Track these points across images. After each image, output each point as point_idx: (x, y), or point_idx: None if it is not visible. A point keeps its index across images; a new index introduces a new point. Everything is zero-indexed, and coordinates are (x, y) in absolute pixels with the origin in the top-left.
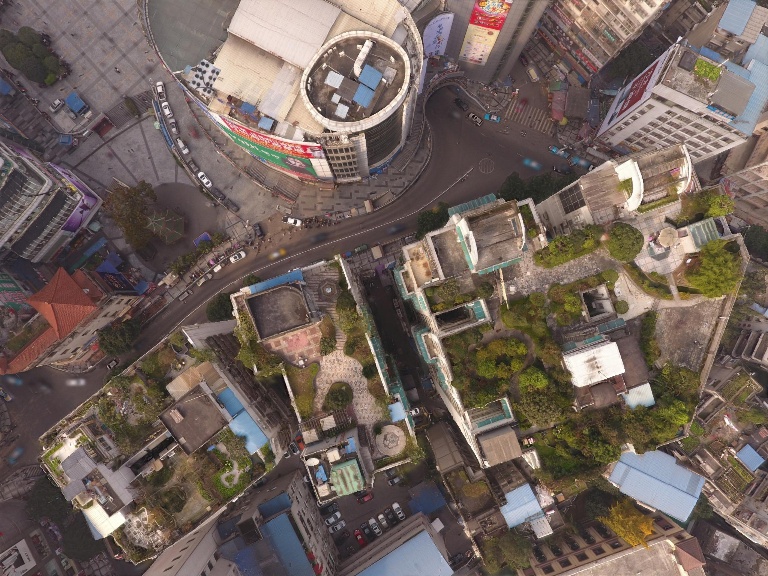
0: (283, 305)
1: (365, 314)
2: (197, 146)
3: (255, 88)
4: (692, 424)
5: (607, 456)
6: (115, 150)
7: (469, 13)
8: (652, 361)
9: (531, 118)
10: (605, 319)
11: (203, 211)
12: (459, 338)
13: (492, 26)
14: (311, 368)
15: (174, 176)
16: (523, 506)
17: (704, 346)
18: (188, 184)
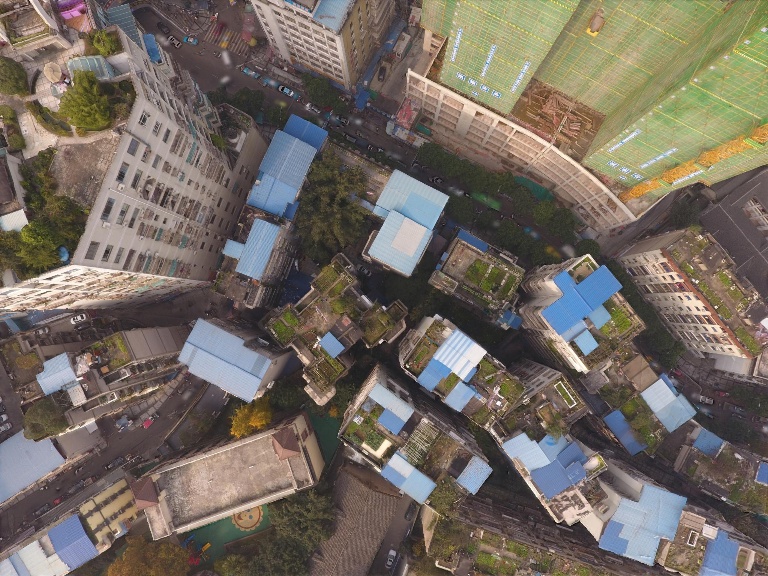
0: None
1: None
2: None
3: None
4: (287, 315)
5: None
6: None
7: None
8: (45, 194)
9: (228, 41)
10: None
11: None
12: None
13: None
14: None
15: None
16: (58, 373)
17: (100, 181)
18: None
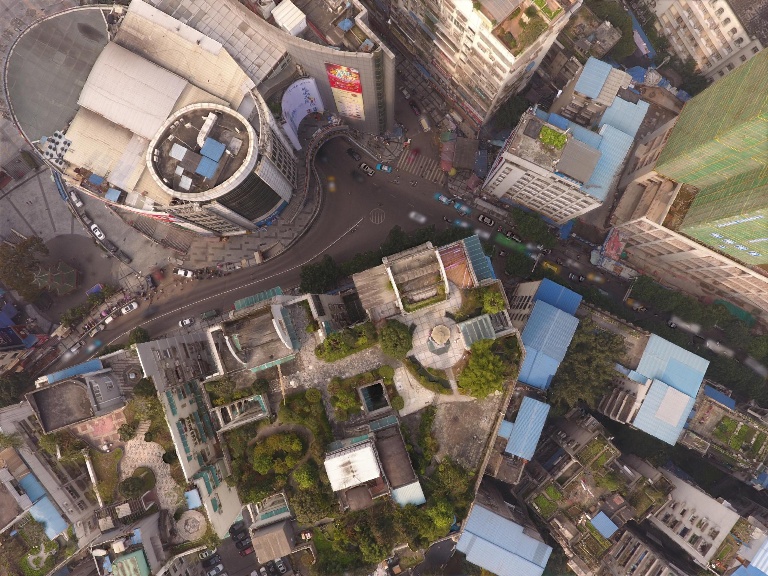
0: (69, 398)
1: (171, 398)
2: (91, 199)
3: (105, 159)
4: (550, 489)
5: (372, 556)
6: (14, 202)
7: (326, 78)
8: (429, 457)
9: (423, 168)
10: (386, 413)
11: (98, 262)
12: (236, 434)
13: (352, 90)
14: (115, 453)
15: (70, 227)
16: None
17: (483, 441)
18: (84, 235)
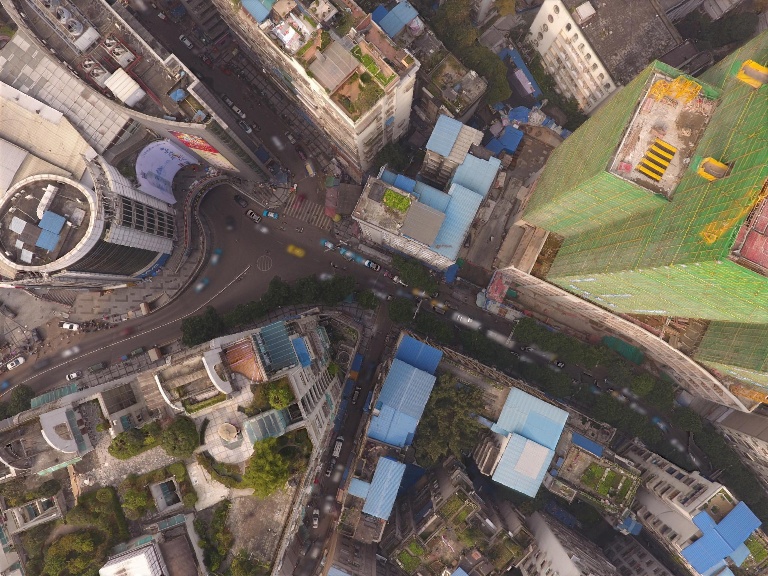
0: None
1: None
2: None
3: None
4: (412, 545)
5: None
6: None
7: None
8: (223, 552)
9: (309, 213)
10: None
11: None
12: None
13: (208, 150)
14: None
15: None
16: None
17: (278, 534)
18: None
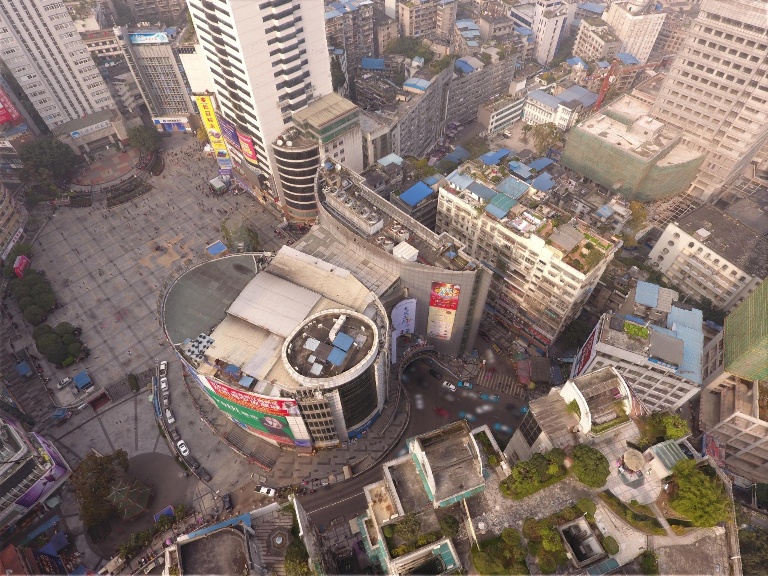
0: (220, 553)
1: (319, 573)
2: (184, 416)
3: (242, 353)
4: None
5: None
6: (104, 422)
7: (428, 298)
8: None
9: (501, 384)
10: None
11: (173, 482)
12: None
13: (448, 307)
14: None
15: (154, 446)
16: None
17: None
18: (165, 454)
